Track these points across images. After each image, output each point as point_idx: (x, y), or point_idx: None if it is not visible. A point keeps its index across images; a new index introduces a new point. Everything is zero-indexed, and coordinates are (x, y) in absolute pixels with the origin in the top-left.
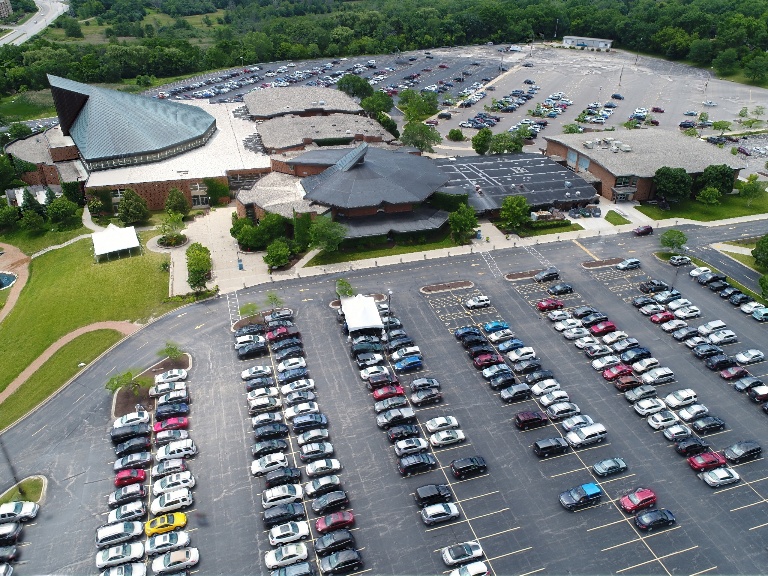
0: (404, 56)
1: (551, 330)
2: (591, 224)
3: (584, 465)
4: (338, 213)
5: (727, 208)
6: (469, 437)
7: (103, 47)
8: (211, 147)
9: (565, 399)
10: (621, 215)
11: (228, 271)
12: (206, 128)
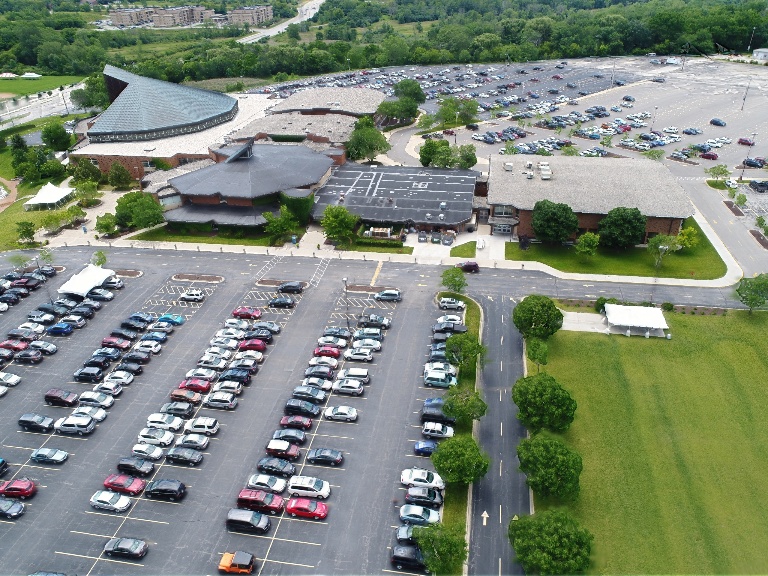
0: (535, 65)
1: (212, 335)
2: (426, 250)
3: (40, 447)
4: (189, 198)
5: (622, 263)
6: (7, 395)
7: (268, 47)
8: (202, 134)
9: (109, 391)
10: (476, 247)
11: (75, 231)
12: (208, 117)
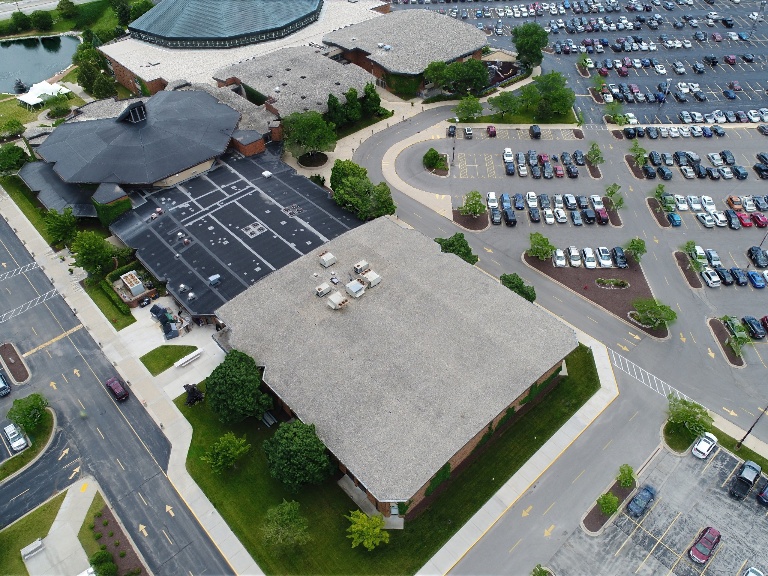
0: None
1: None
2: (136, 334)
3: None
4: None
5: (263, 501)
6: None
7: None
8: (226, 52)
9: None
10: None
11: None
12: (243, 33)
